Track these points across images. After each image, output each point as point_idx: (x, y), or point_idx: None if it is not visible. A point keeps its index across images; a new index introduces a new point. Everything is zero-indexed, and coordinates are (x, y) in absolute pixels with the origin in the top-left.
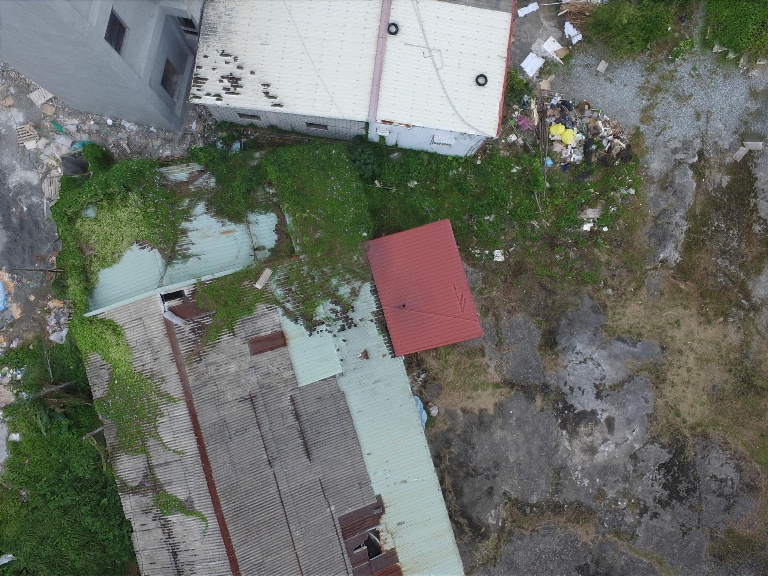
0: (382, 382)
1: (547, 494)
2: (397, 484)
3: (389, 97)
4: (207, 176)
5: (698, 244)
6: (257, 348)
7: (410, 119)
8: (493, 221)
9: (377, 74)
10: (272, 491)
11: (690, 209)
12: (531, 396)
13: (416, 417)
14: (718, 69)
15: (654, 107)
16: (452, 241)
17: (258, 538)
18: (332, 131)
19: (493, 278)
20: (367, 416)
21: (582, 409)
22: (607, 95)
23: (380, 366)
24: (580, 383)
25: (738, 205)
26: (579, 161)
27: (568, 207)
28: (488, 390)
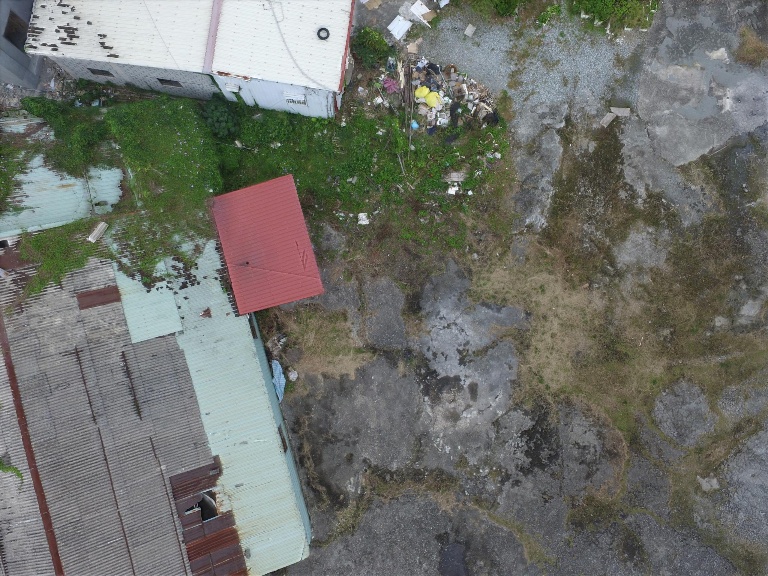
0: (225, 341)
1: (407, 461)
2: (237, 445)
3: (226, 48)
4: (47, 129)
5: (564, 209)
6: (87, 302)
7: (248, 71)
8: (355, 183)
9: (214, 25)
10: (95, 448)
11: (557, 174)
12: (393, 361)
13: (260, 377)
14: (586, 35)
15: (522, 72)
16: (295, 197)
17: (76, 495)
18: (188, 89)
19: (357, 242)
20: (208, 375)
21: (445, 375)
22: (474, 59)
23: (223, 325)
24: (443, 348)
25: (605, 171)
26: (445, 125)
27: (432, 170)
28: (349, 355)
